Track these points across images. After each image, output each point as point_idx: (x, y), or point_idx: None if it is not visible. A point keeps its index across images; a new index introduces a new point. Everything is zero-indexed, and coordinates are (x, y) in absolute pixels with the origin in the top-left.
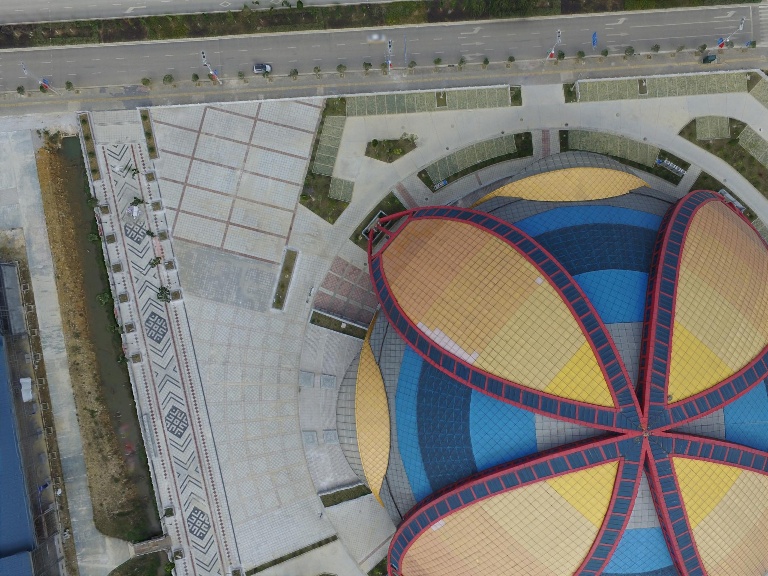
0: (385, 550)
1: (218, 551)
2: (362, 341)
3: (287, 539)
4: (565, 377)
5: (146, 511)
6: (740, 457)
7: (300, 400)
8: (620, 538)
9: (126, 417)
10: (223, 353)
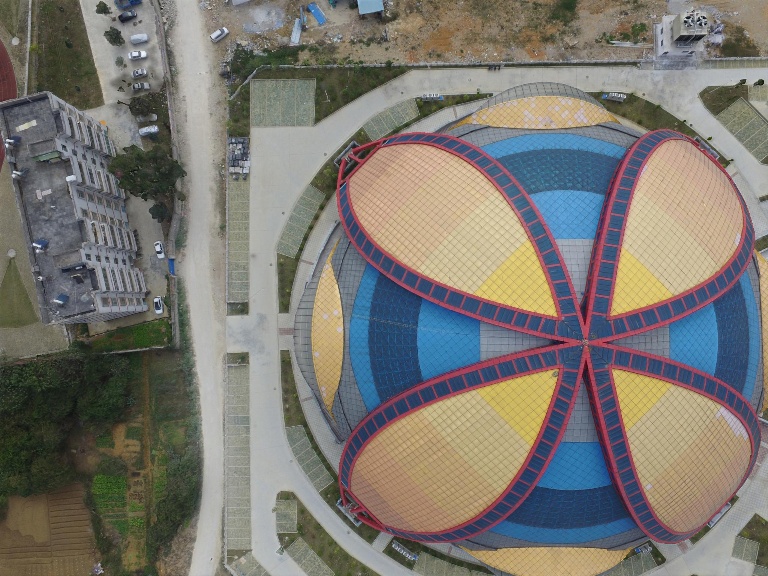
0: None
1: None
2: None
3: None
4: (652, 398)
5: None
6: (480, 308)
7: None
8: (603, 237)
9: None
10: None
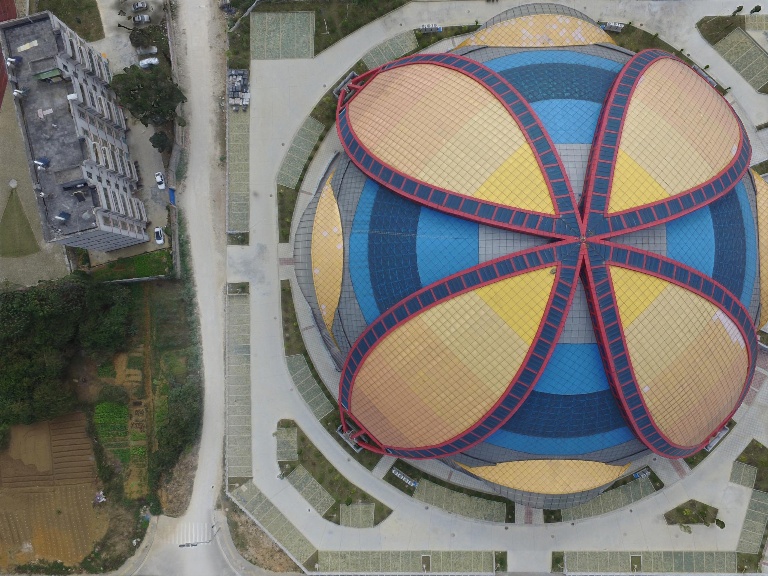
0: None
1: None
2: None
3: None
4: (649, 296)
5: None
6: (478, 209)
7: None
8: (600, 138)
9: None
10: None
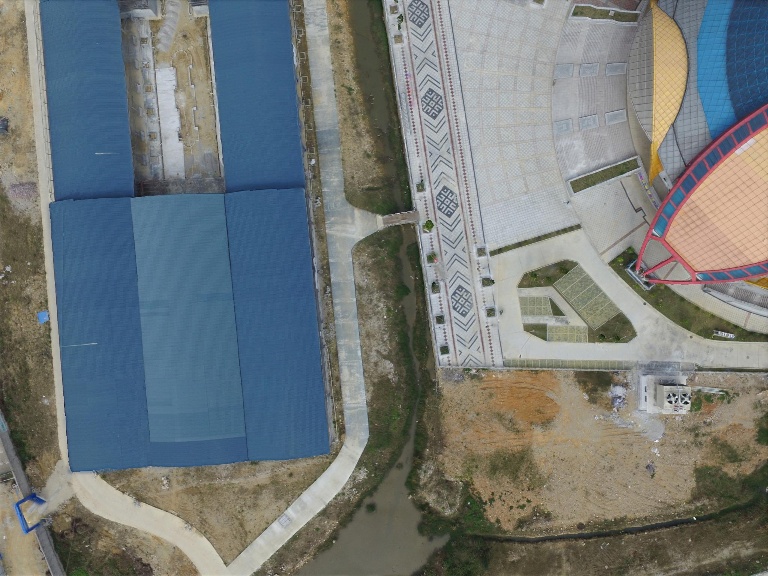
0: (627, 243)
1: (464, 230)
2: (633, 24)
3: (532, 224)
4: None
5: (392, 191)
6: None
7: (554, 93)
8: None
9: (379, 100)
10: (482, 42)
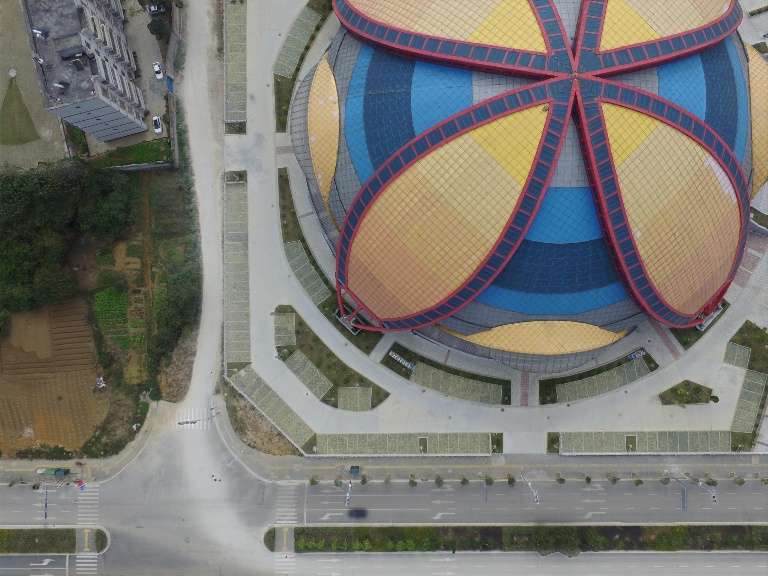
0: None
1: None
2: None
3: None
4: (640, 134)
5: None
6: (472, 52)
7: None
8: None
9: None
10: None
